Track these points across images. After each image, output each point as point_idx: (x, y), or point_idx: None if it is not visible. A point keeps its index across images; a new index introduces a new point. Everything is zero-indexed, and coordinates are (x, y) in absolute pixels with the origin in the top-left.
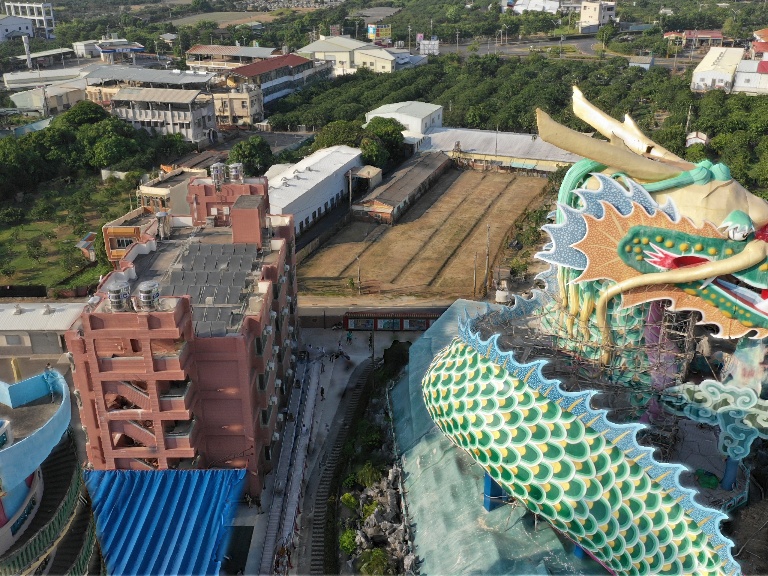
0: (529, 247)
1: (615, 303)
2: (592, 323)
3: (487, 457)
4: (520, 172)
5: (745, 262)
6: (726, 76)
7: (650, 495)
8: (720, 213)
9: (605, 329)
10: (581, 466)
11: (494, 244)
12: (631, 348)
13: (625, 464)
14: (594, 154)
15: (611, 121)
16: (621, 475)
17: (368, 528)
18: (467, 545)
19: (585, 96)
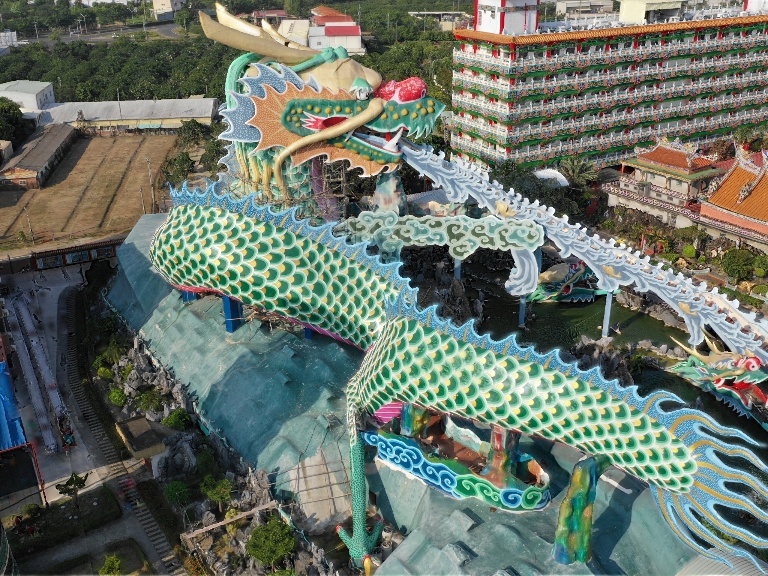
0: (181, 184)
1: (287, 165)
2: (273, 185)
3: (227, 279)
4: (148, 132)
5: (371, 114)
6: (302, 41)
7: (350, 269)
8: (348, 81)
9: (284, 187)
10: (299, 262)
11: (147, 188)
12: (305, 198)
13: (329, 253)
14: (250, 46)
15: (253, 27)
16: (328, 261)
17: (131, 383)
18: (224, 357)
19: (184, 68)
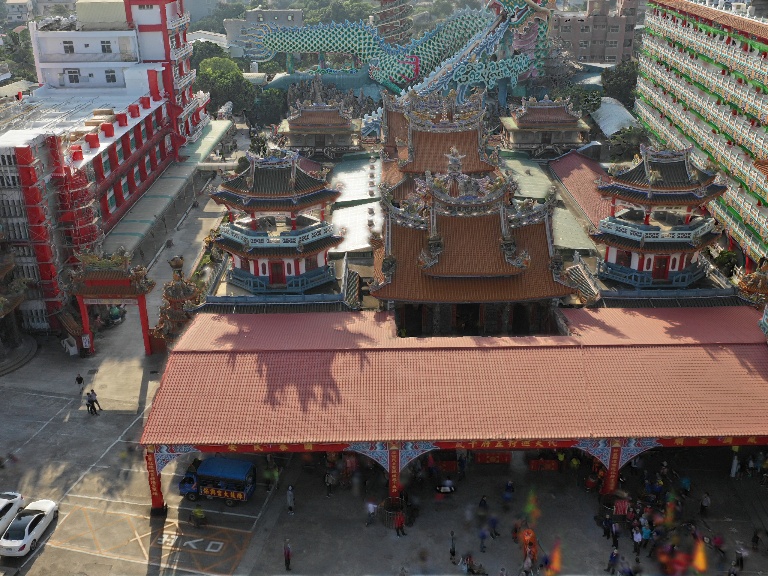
0: None
1: None
2: None
3: None
4: None
5: None
6: None
7: None
8: None
9: None
10: None
11: None
12: None
13: None
14: None
15: None
16: None
17: None
18: None
19: None
